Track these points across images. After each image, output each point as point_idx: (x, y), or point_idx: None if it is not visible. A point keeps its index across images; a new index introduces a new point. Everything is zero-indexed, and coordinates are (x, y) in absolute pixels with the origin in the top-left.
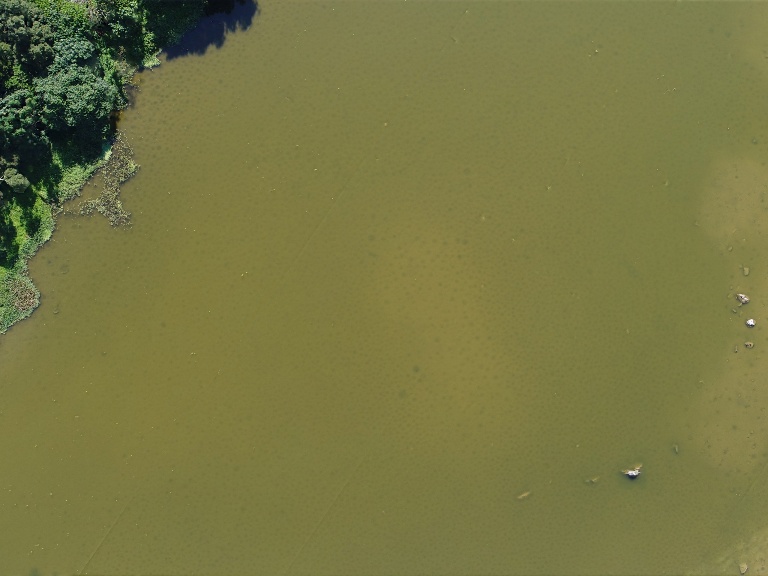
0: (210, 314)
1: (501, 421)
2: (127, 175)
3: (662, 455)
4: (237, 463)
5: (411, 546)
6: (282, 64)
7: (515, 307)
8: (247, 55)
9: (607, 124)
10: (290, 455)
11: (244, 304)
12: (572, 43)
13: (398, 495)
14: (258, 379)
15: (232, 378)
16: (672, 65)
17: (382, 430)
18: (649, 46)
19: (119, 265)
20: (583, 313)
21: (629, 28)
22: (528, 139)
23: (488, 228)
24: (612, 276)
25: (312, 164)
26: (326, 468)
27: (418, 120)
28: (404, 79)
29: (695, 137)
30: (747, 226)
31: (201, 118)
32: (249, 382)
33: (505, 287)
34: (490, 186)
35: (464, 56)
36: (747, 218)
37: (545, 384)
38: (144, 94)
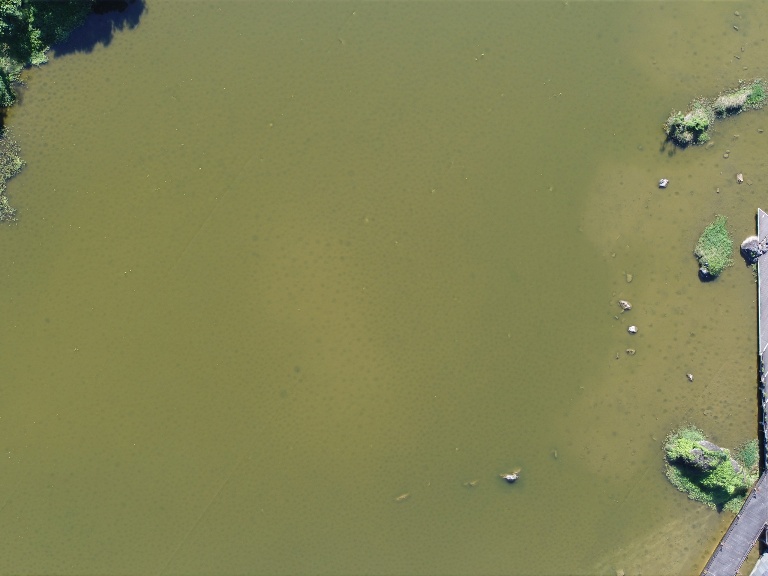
0: (94, 311)
1: (381, 423)
2: (13, 171)
3: (541, 460)
4: (118, 459)
5: (289, 545)
6: (169, 63)
7: (397, 309)
8: (134, 54)
9: (492, 128)
10: (171, 452)
11: (127, 301)
12: (459, 46)
13: (277, 494)
14: (140, 376)
15: (114, 375)
16: (559, 70)
17: (262, 429)
18: (536, 50)
19: (5, 260)
20: (465, 317)
21: (516, 32)
22: (413, 142)
23: (371, 230)
24: (494, 280)
25: (197, 163)
26: (206, 466)
27: (303, 121)
28: (290, 80)
29: (581, 142)
30: (631, 233)
31: (88, 116)
32: (131, 379)
33: (387, 289)
34: (374, 188)
35: (350, 58)
36: (631, 225)
37: (425, 387)
38: (31, 91)
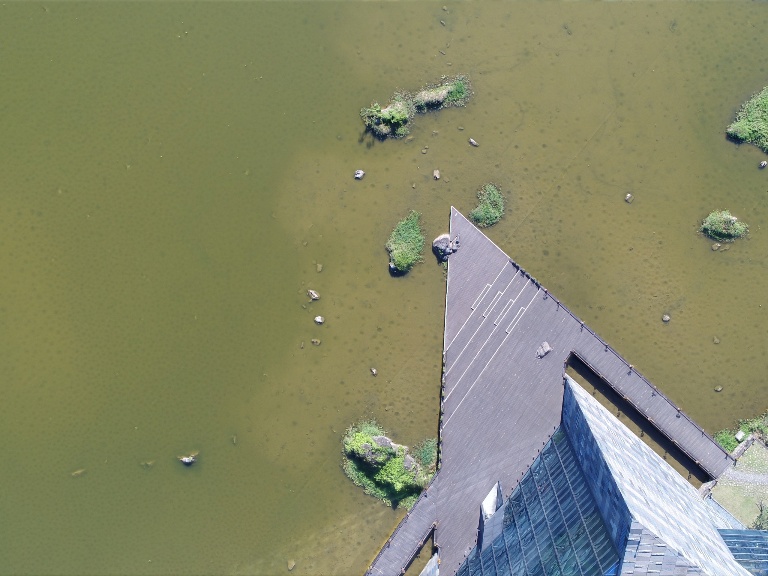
0: None
1: (61, 396)
2: None
3: (220, 444)
4: None
5: None
6: None
7: (84, 283)
8: None
9: (192, 107)
10: None
11: None
12: (164, 22)
13: None
14: None
15: None
16: (263, 53)
17: None
18: (241, 32)
19: None
20: (152, 295)
21: (222, 12)
22: (111, 116)
23: (63, 202)
24: (184, 261)
25: None
26: None
27: (2, 87)
28: None
29: (280, 128)
30: (324, 222)
31: None
32: None
33: (76, 263)
34: (69, 160)
35: (54, 26)
36: (325, 214)
37: (108, 363)
38: None
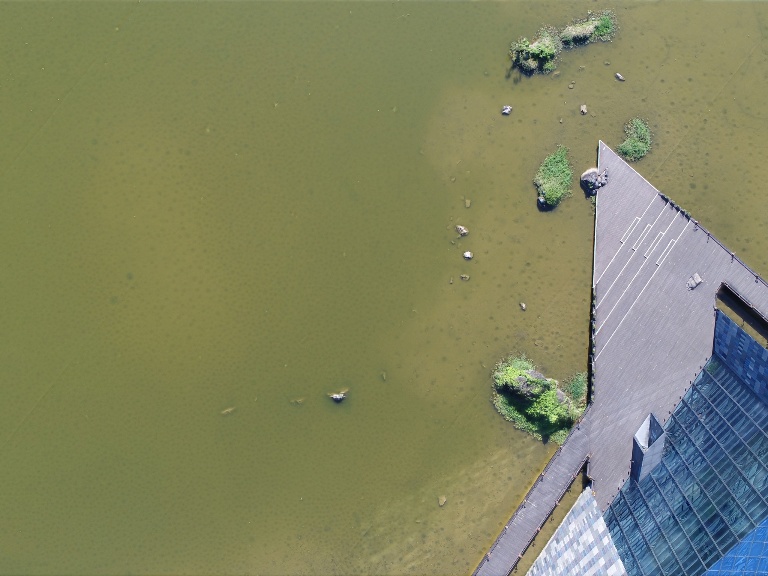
0: None
1: (210, 335)
2: None
3: (369, 381)
4: None
5: (112, 453)
6: None
7: (233, 222)
8: None
9: (339, 45)
10: None
11: None
12: None
13: (102, 401)
14: None
15: None
16: None
17: (91, 335)
18: None
19: None
20: (301, 233)
21: None
22: (258, 54)
23: (212, 141)
24: (333, 198)
25: (40, 63)
26: (33, 368)
27: (150, 27)
28: None
29: (427, 65)
30: (472, 158)
31: None
32: None
33: (224, 201)
34: (217, 99)
35: None
36: (472, 150)
37: (257, 301)
38: None
